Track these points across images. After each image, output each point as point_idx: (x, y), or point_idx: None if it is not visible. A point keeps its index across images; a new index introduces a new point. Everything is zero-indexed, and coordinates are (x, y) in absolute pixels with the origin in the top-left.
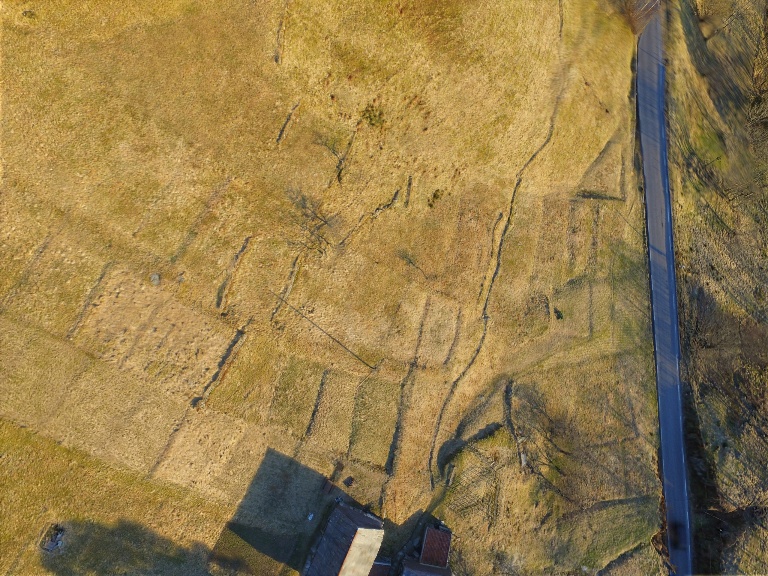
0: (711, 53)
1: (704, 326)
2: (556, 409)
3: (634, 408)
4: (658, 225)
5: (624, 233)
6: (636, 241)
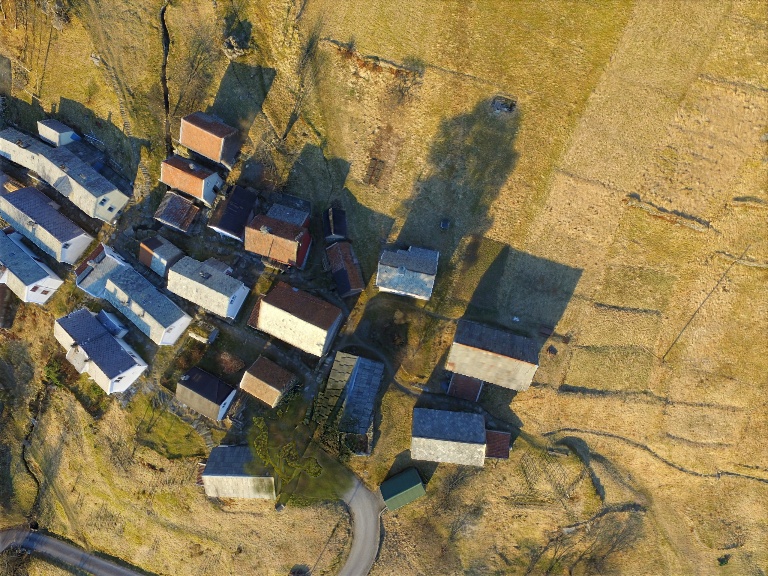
0: None
1: None
2: (616, 563)
3: None
4: None
5: None
6: None
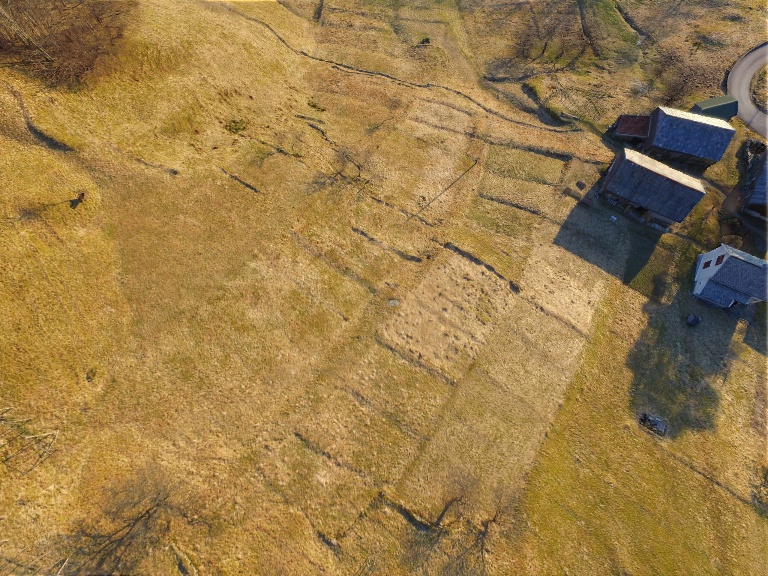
0: None
1: None
2: (507, 52)
3: (506, 3)
4: None
5: None
6: None
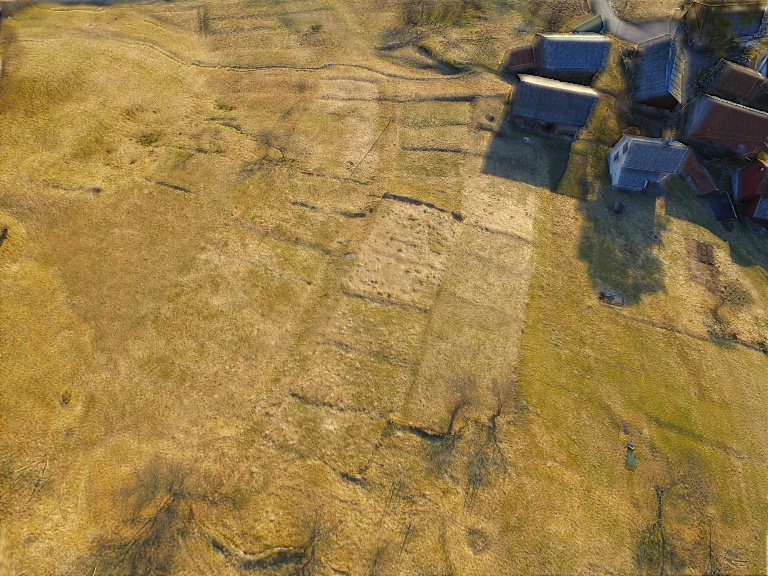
0: None
1: None
2: (390, 22)
3: None
4: None
5: (229, 3)
6: None
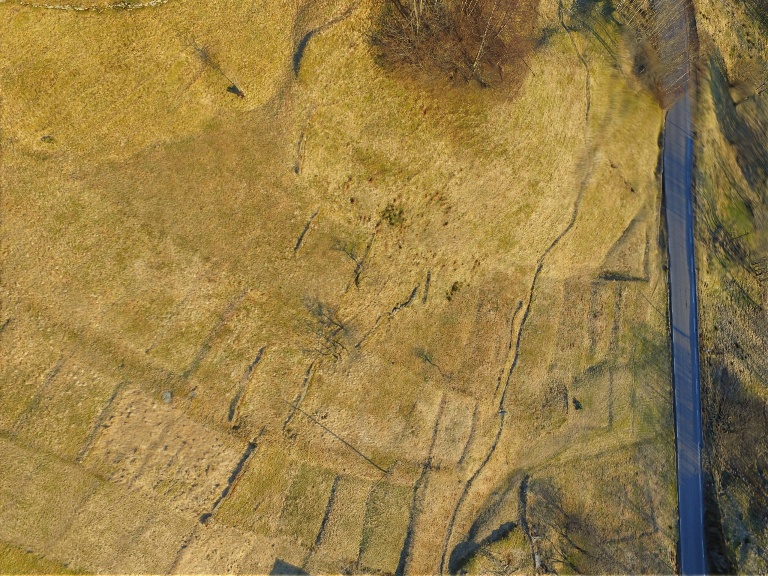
0: (740, 117)
1: (727, 408)
2: (572, 504)
3: (653, 501)
4: (682, 306)
5: (647, 315)
6: (659, 323)
